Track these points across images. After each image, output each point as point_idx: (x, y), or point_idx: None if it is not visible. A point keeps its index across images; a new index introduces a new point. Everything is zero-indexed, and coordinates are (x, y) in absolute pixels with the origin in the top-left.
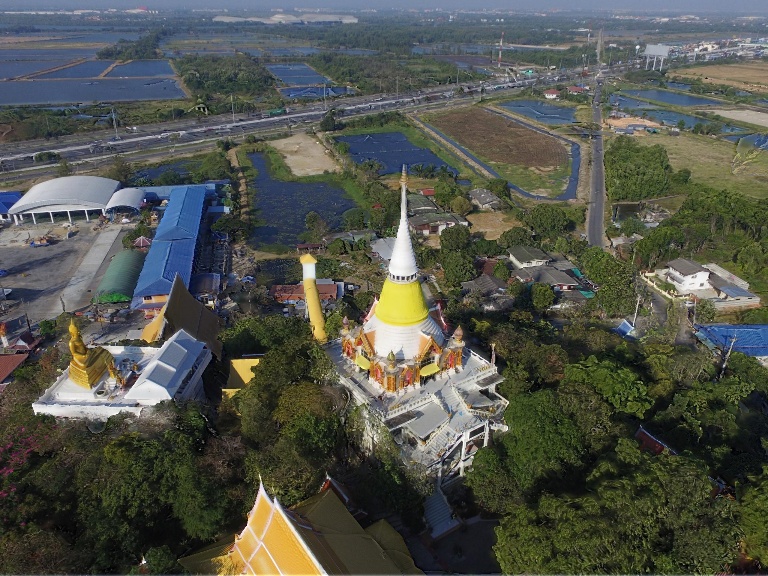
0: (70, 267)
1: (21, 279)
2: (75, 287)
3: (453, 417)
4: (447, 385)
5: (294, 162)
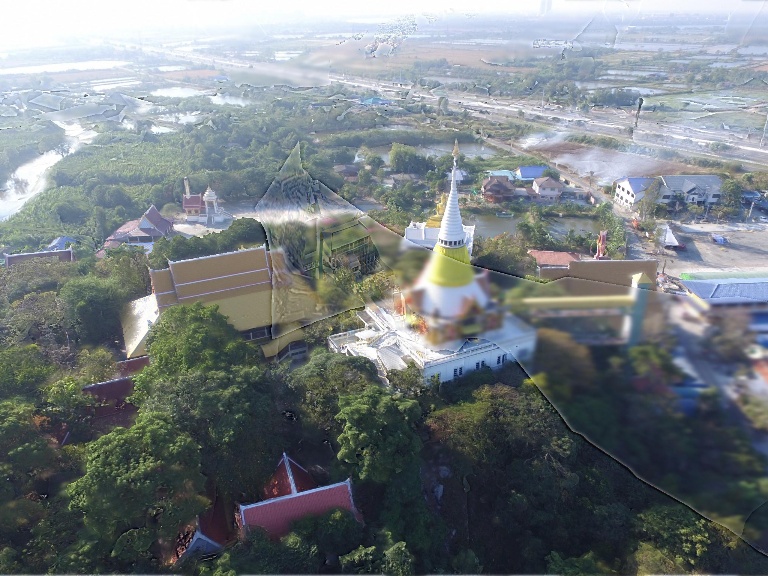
0: (758, 263)
1: (716, 250)
2: (718, 271)
3: (374, 347)
4: (407, 339)
5: None
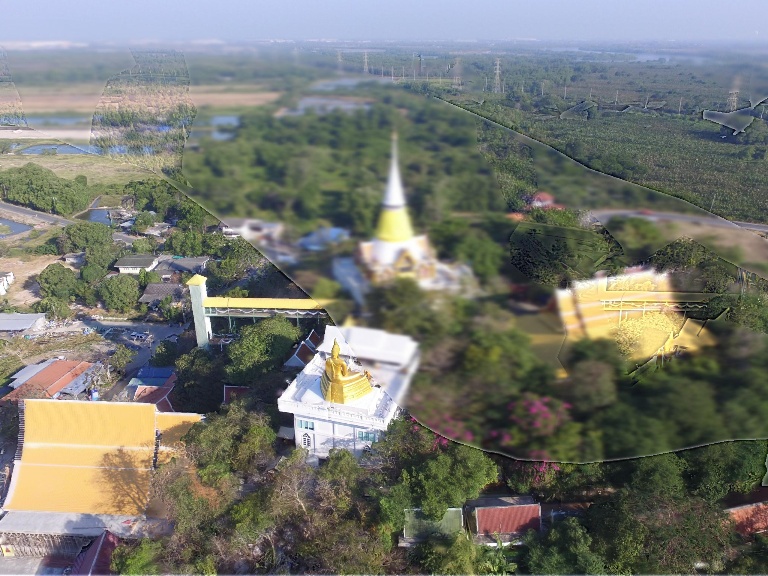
0: None
1: None
2: None
3: None
4: None
5: None
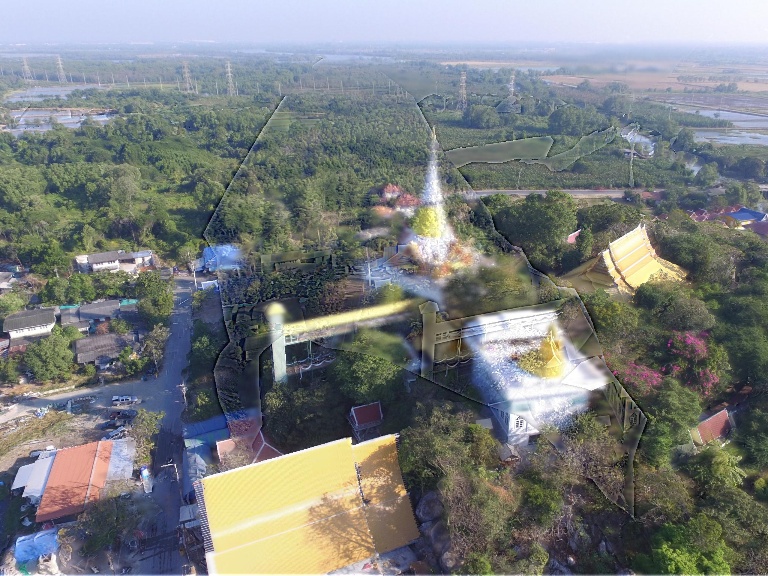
0: None
1: None
2: None
3: None
4: None
5: None
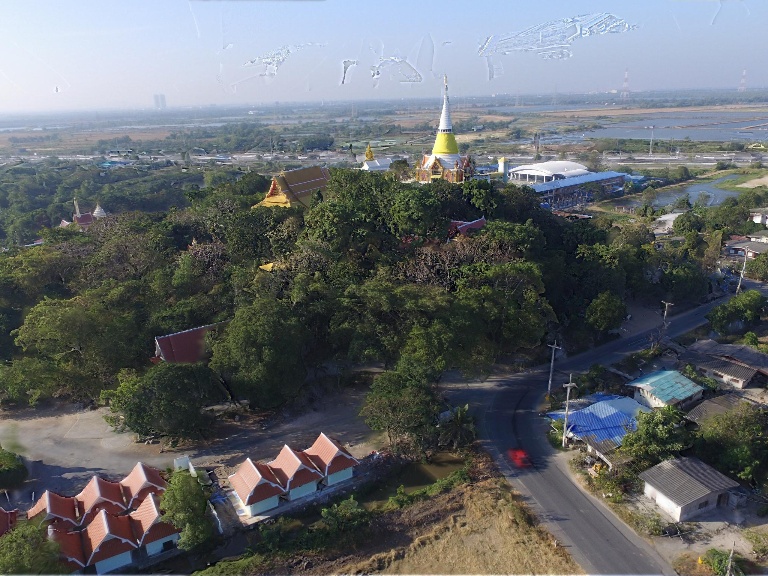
0: None
1: None
2: None
3: None
4: None
5: (759, 181)
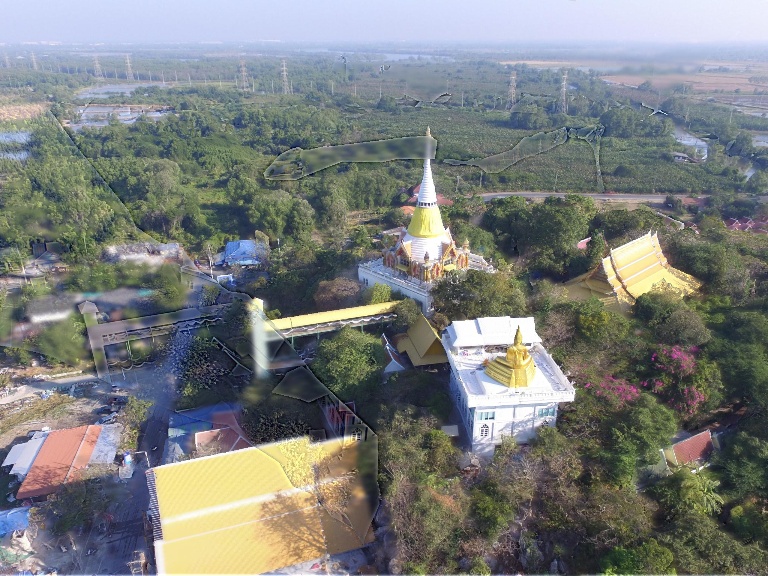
0: None
1: None
2: None
3: None
4: None
5: None
